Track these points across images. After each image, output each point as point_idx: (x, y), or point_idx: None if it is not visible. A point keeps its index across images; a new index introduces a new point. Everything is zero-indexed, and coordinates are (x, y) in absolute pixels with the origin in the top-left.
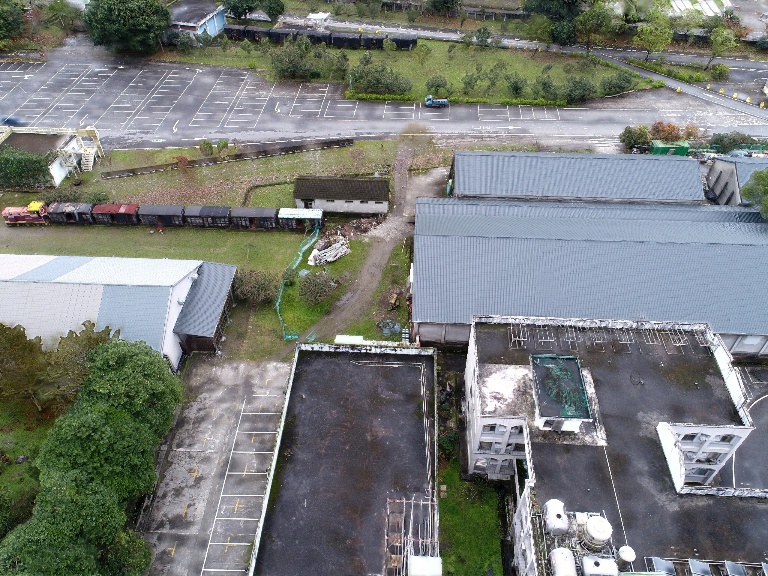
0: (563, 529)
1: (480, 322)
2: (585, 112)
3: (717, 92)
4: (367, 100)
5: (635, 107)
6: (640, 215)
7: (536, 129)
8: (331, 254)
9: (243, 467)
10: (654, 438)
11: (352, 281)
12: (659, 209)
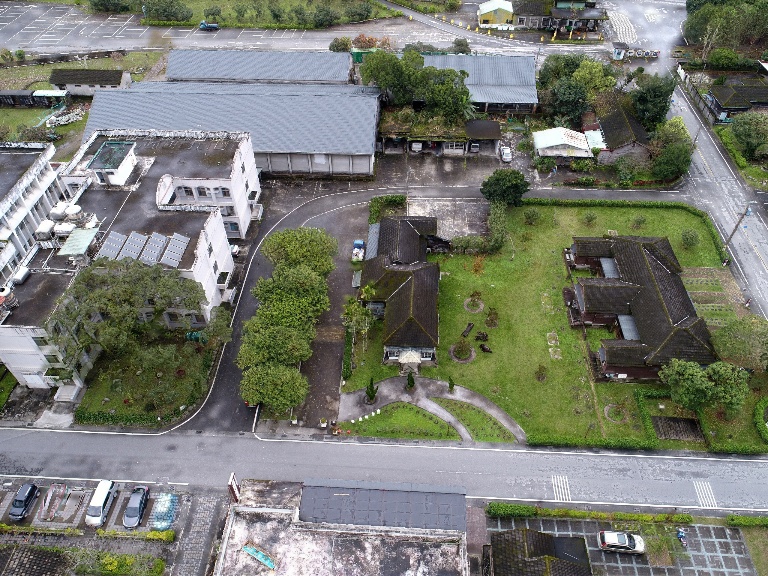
0: (56, 213)
1: (102, 135)
2: (325, 33)
3: (441, 19)
4: (157, 26)
5: (368, 30)
6: (293, 90)
7: (277, 44)
8: (64, 119)
9: None
10: None
11: (73, 136)
12: (309, 86)
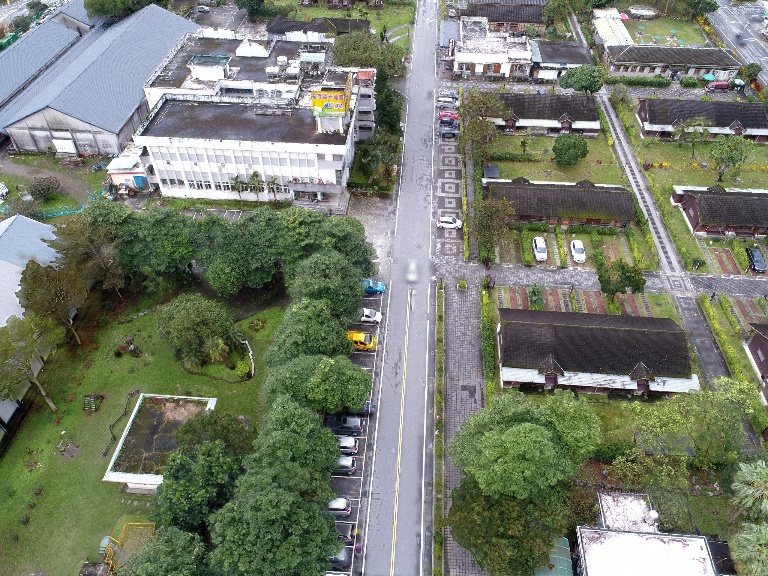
0: None
1: None
2: None
3: None
4: None
5: None
6: (76, 54)
7: None
8: (0, 189)
9: None
10: (241, 57)
11: None
12: (77, 47)
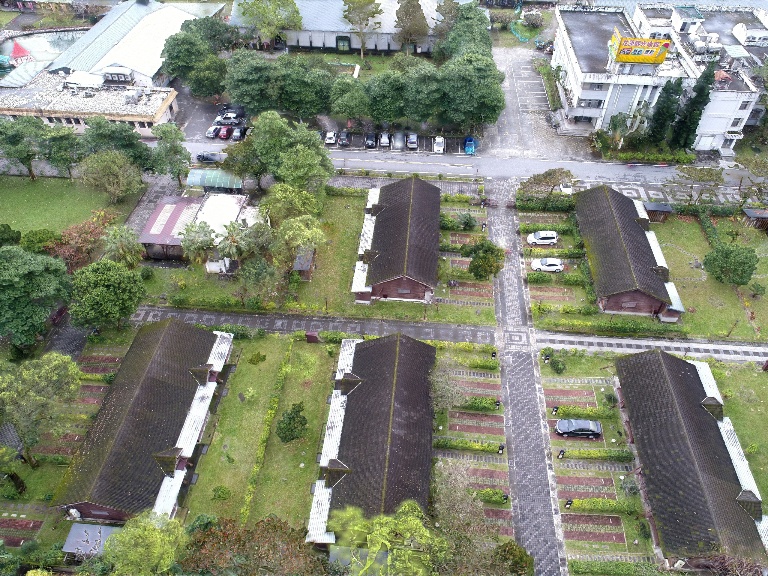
0: (698, 39)
1: None
2: None
3: None
4: None
5: None
6: None
7: None
8: None
9: (521, 75)
10: (731, 35)
11: (548, 25)
12: None
